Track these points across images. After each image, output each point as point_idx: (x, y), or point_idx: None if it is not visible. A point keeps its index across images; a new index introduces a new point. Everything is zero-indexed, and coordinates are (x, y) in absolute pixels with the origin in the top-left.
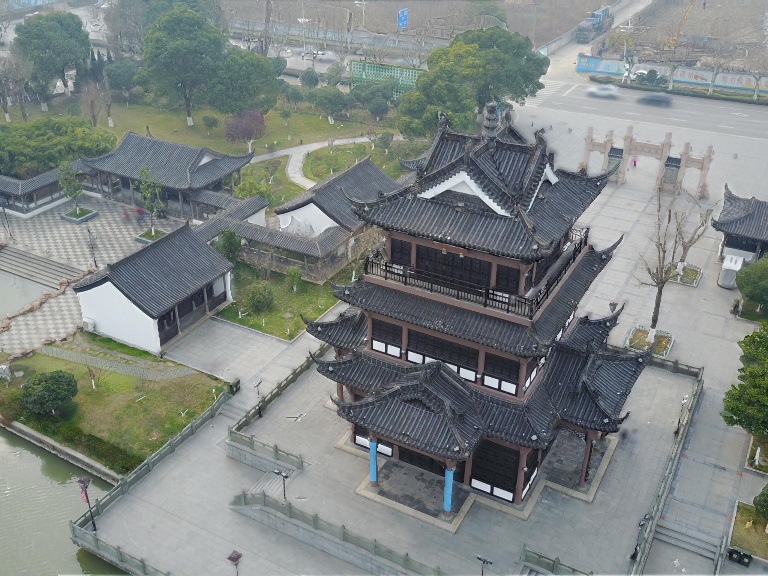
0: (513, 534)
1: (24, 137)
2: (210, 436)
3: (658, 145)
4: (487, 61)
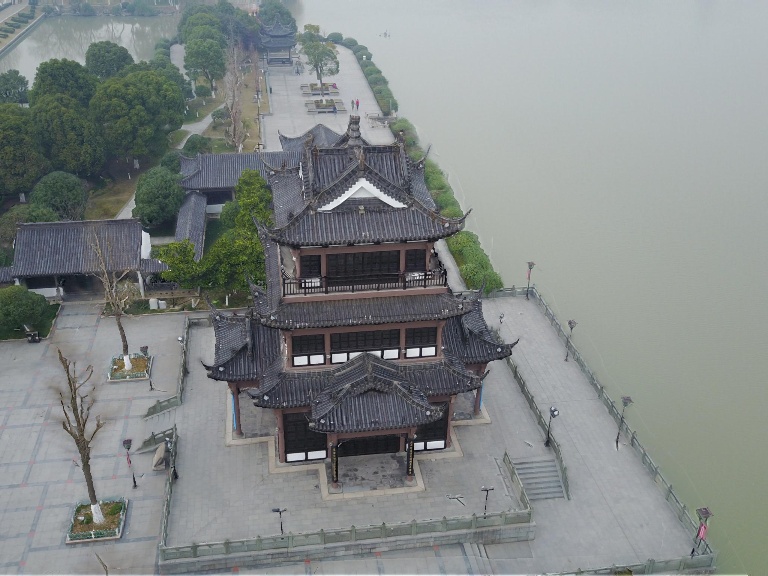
0: None
1: None
2: (530, 570)
3: None
4: None
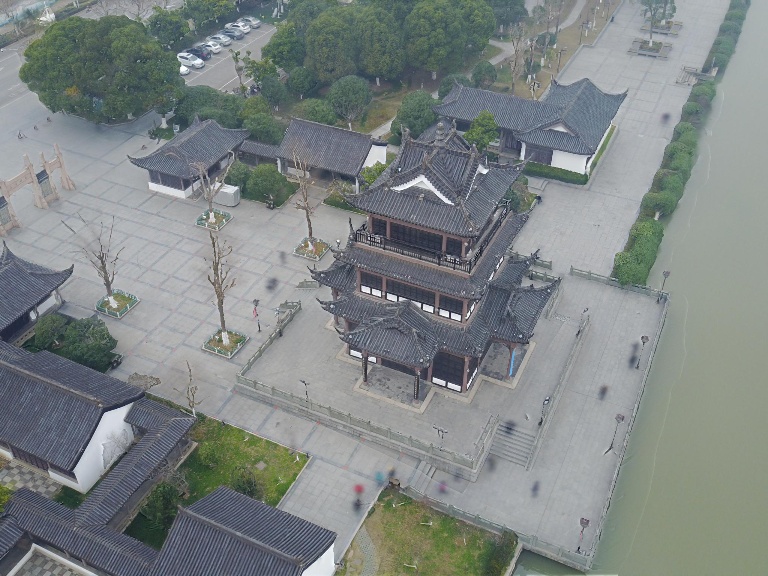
0: None
1: None
2: (453, 500)
3: (24, 172)
4: None
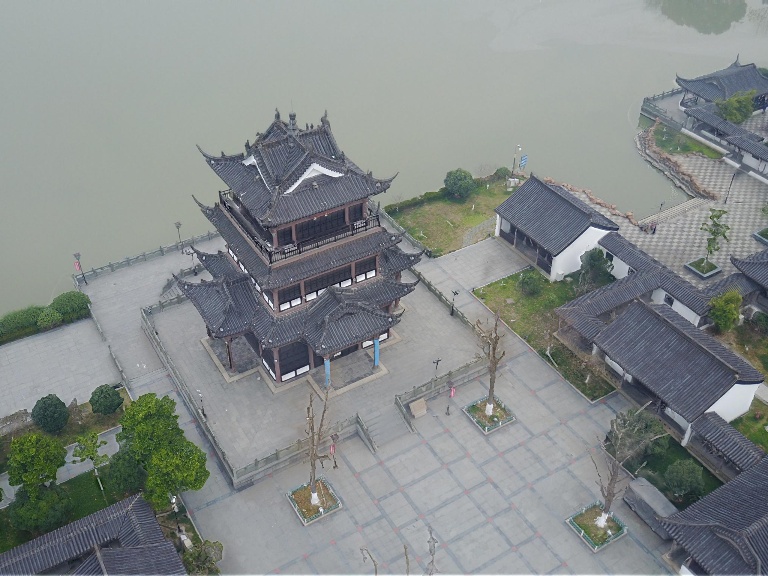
0: None
1: None
2: None
3: None
4: None
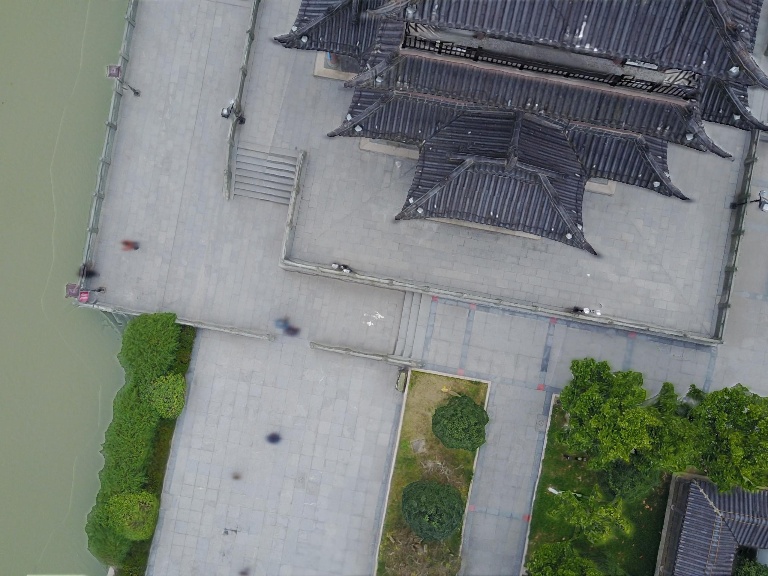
0: (335, 138)
1: None
2: None
3: None
4: None
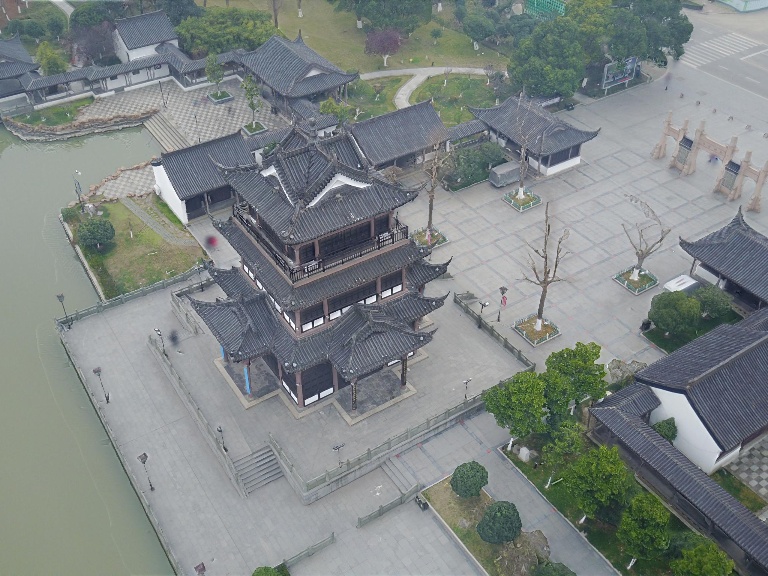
0: (281, 424)
1: (208, 23)
2: None
3: (723, 146)
4: (611, 20)
